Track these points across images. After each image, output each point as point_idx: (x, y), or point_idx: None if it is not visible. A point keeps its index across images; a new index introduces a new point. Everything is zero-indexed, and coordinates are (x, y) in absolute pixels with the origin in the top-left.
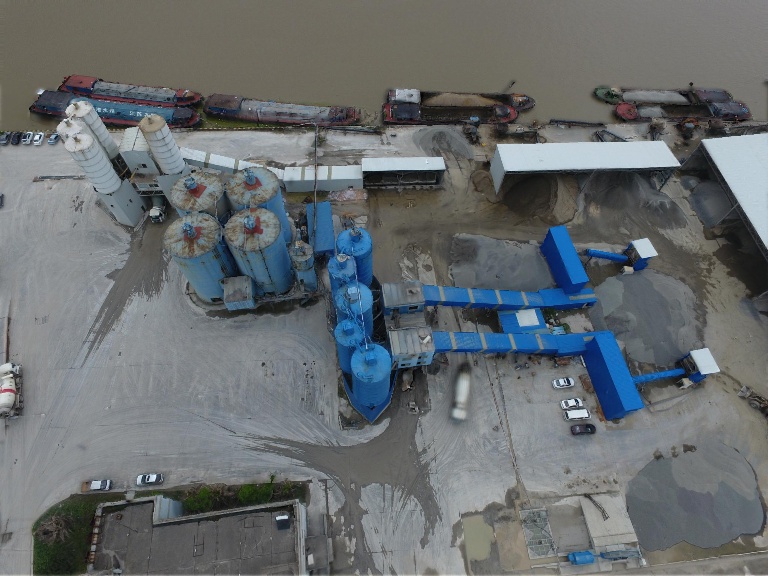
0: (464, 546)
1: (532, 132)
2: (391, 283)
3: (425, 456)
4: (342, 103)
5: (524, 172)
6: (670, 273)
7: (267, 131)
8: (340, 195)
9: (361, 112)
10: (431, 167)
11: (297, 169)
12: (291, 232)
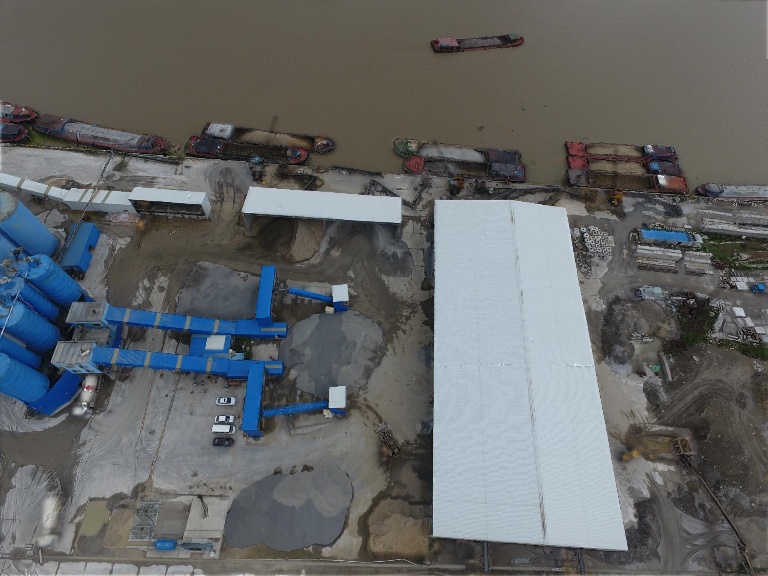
0: (80, 523)
1: (308, 176)
2: (81, 302)
3: (83, 448)
4: (162, 131)
5: (260, 215)
6: (371, 316)
7: (79, 152)
8: (115, 217)
9: (165, 143)
10: (190, 201)
11: (80, 191)
12: (57, 246)
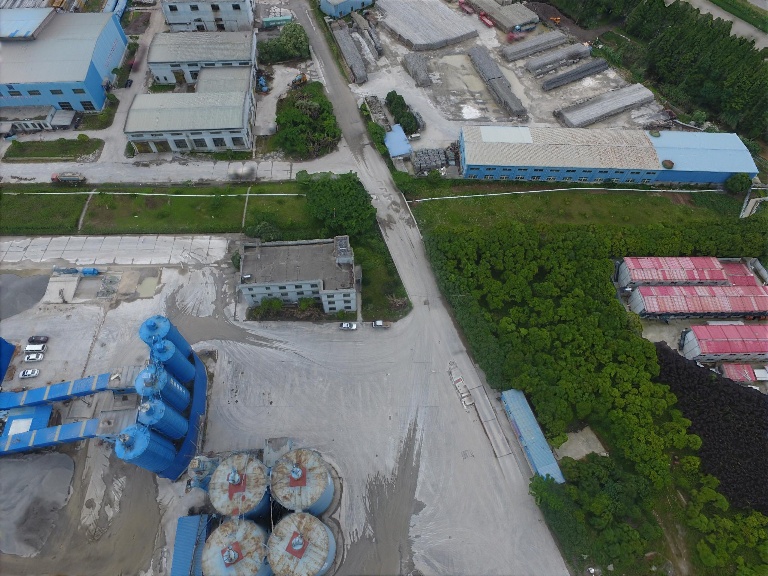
0: (158, 284)
1: None
2: None
3: None
4: None
5: None
6: None
7: None
8: None
9: None
10: None
11: None
12: None
